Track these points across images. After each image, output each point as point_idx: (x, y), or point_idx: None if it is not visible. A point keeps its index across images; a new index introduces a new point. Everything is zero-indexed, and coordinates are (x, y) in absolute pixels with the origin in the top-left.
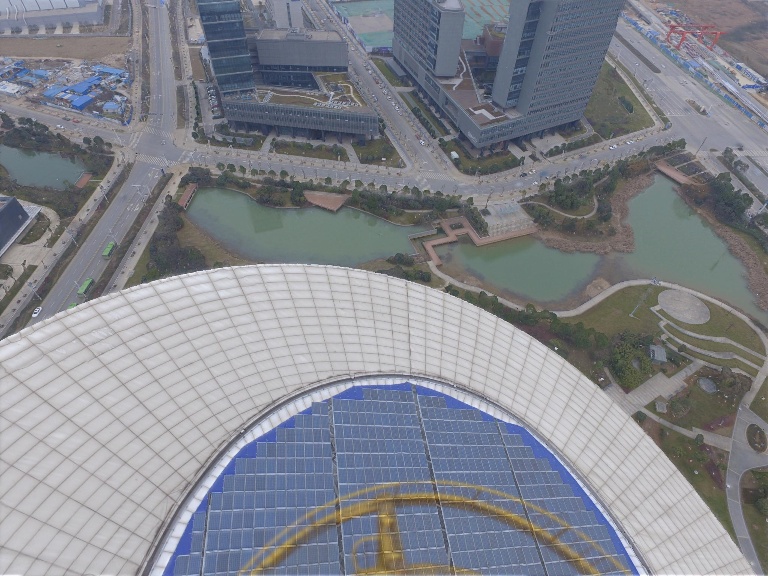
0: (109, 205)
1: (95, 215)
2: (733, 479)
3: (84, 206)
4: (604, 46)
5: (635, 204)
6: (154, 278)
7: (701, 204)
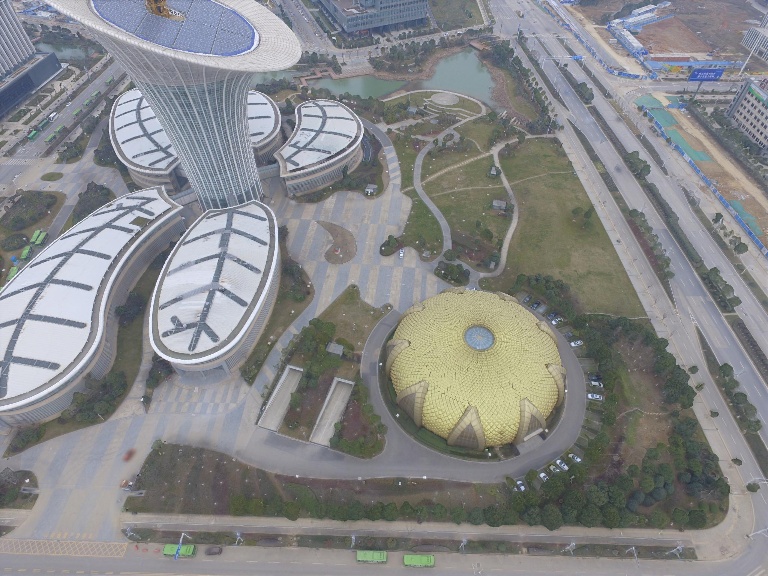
0: (110, 65)
1: (101, 69)
2: (426, 149)
3: (94, 66)
4: None
5: (456, 68)
6: (134, 85)
7: (485, 58)
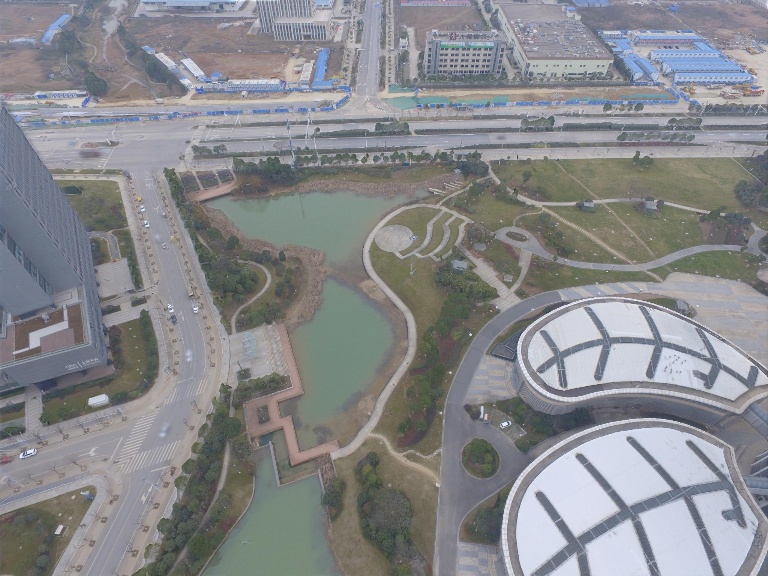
0: None
1: None
2: None
3: None
4: (34, 155)
5: None
6: None
7: (267, 189)
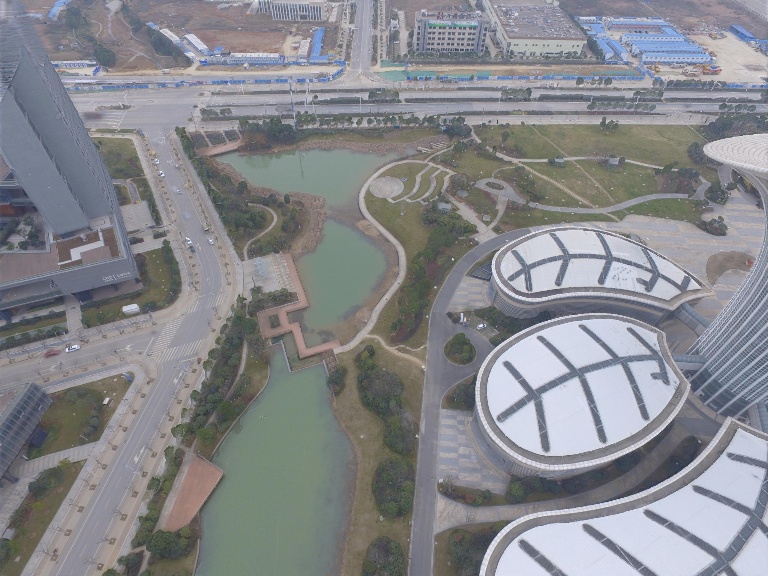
0: None
1: None
2: None
3: None
4: None
5: None
6: None
7: (271, 146)
